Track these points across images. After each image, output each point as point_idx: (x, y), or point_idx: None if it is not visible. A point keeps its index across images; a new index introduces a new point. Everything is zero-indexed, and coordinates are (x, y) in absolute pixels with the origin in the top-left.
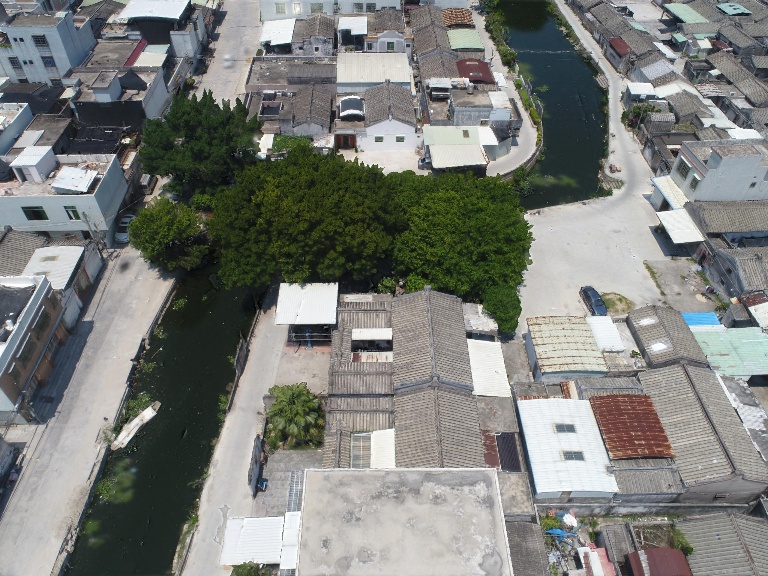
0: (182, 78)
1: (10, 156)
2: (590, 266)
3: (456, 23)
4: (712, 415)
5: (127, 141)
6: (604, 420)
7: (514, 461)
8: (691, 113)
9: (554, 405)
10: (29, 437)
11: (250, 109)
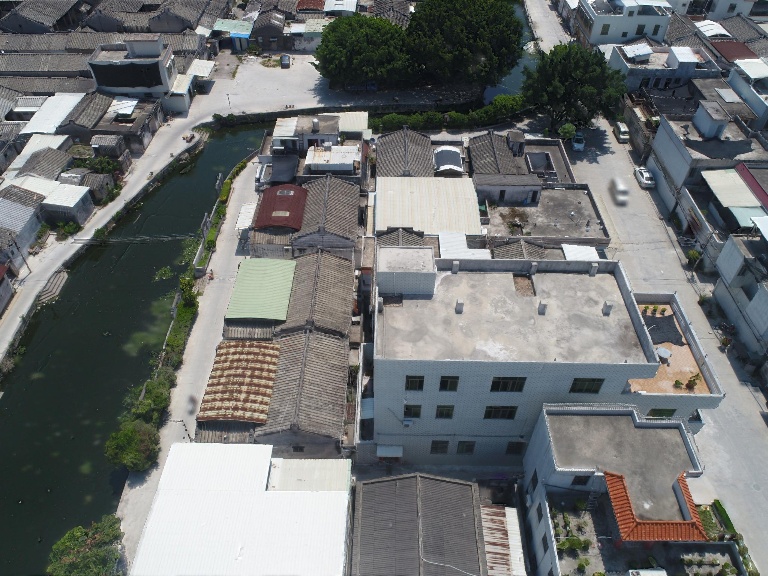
0: (687, 215)
1: (722, 83)
2: (272, 78)
3: (258, 342)
4: (276, 0)
5: (654, 118)
6: (321, 5)
7: (362, 8)
8: (60, 151)
9: (340, 8)
10: (572, 39)
11: (567, 173)
